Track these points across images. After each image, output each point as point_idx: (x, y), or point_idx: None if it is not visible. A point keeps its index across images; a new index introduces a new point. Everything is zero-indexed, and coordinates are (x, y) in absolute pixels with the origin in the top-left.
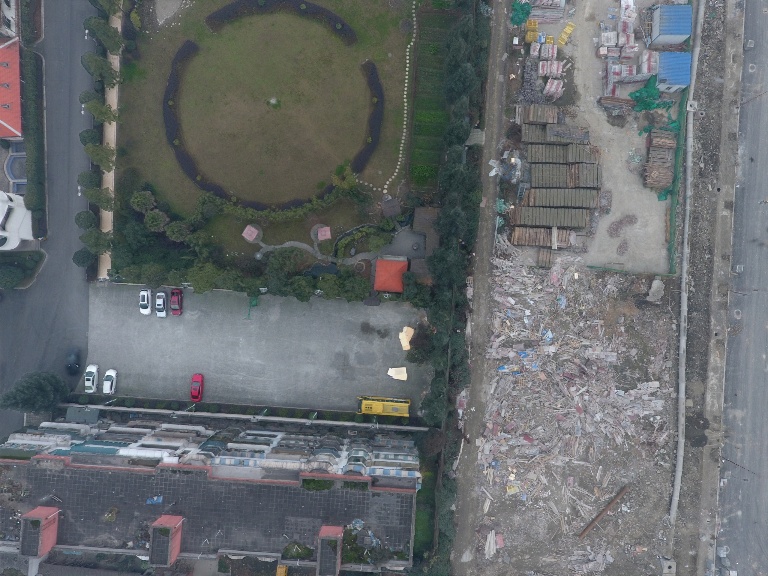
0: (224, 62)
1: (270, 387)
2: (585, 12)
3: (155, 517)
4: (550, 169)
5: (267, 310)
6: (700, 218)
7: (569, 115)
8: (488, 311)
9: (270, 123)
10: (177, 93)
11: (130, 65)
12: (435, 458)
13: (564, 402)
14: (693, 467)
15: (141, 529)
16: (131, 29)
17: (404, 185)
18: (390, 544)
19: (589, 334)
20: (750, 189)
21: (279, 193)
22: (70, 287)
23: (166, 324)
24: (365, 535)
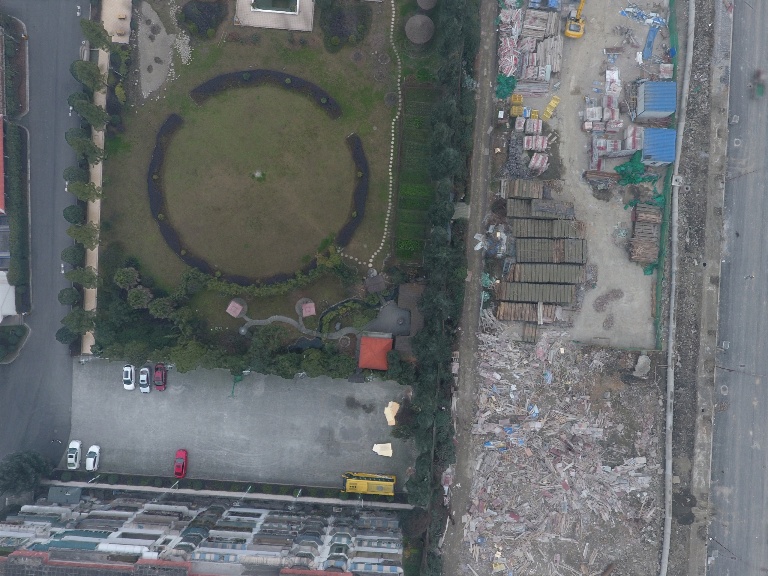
0: (209, 135)
1: (254, 463)
2: (570, 86)
3: None
4: (535, 244)
5: (252, 385)
6: (686, 293)
7: (554, 189)
8: (474, 386)
9: (255, 197)
10: (162, 167)
11: (115, 139)
12: (420, 537)
13: (550, 478)
14: (680, 545)
15: None
16: (116, 103)
17: (389, 259)
18: None
19: (575, 410)
20: (736, 264)
21: (264, 267)
22: (53, 362)
23: (150, 399)
24: None
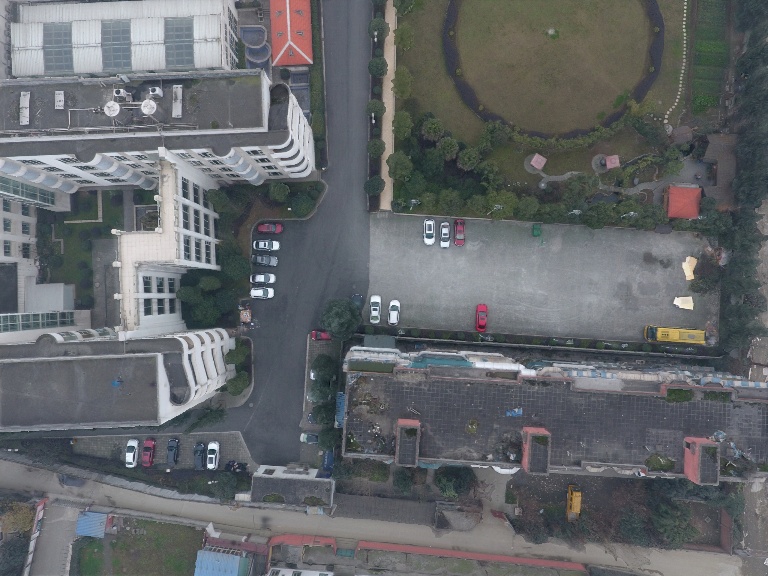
0: None
1: (553, 318)
2: None
3: (515, 429)
4: None
5: (549, 240)
6: None
7: None
8: None
9: (549, 54)
10: (456, 24)
11: None
12: None
13: None
14: None
15: (502, 441)
16: None
17: (685, 115)
18: (752, 456)
19: None
20: None
21: (559, 123)
22: (351, 218)
23: (447, 255)
24: (727, 447)
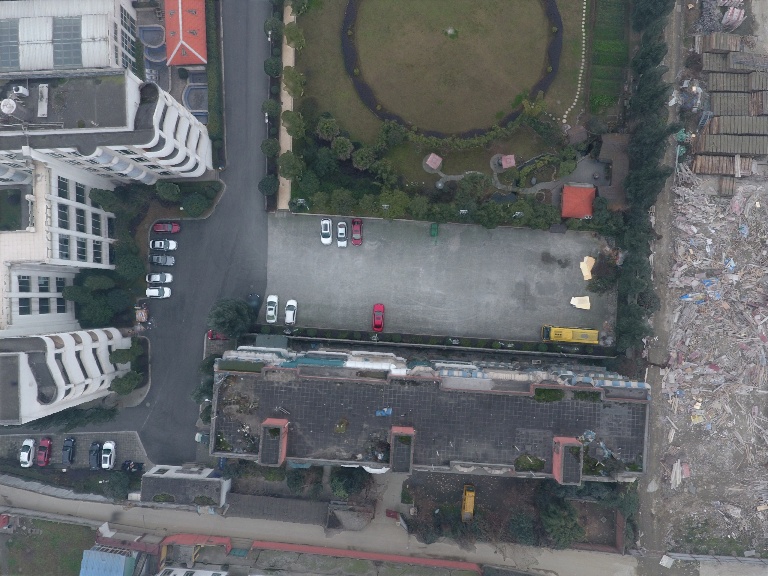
0: None
1: (451, 317)
2: None
3: (384, 429)
4: (732, 97)
5: (447, 240)
6: None
7: (748, 45)
8: (670, 240)
9: (448, 53)
10: (355, 23)
11: None
12: None
13: (747, 331)
14: None
15: (371, 441)
16: None
17: (583, 115)
18: (622, 455)
19: None
20: None
21: (458, 123)
22: (249, 217)
23: (345, 254)
24: (597, 446)
